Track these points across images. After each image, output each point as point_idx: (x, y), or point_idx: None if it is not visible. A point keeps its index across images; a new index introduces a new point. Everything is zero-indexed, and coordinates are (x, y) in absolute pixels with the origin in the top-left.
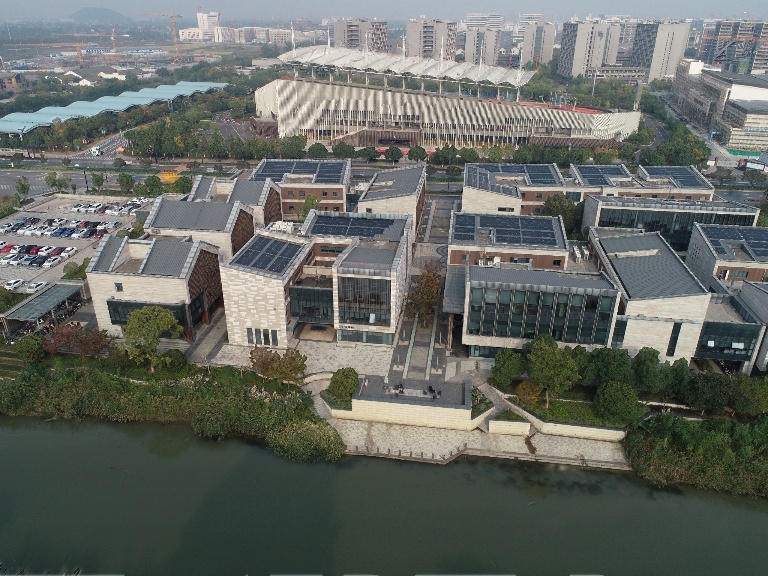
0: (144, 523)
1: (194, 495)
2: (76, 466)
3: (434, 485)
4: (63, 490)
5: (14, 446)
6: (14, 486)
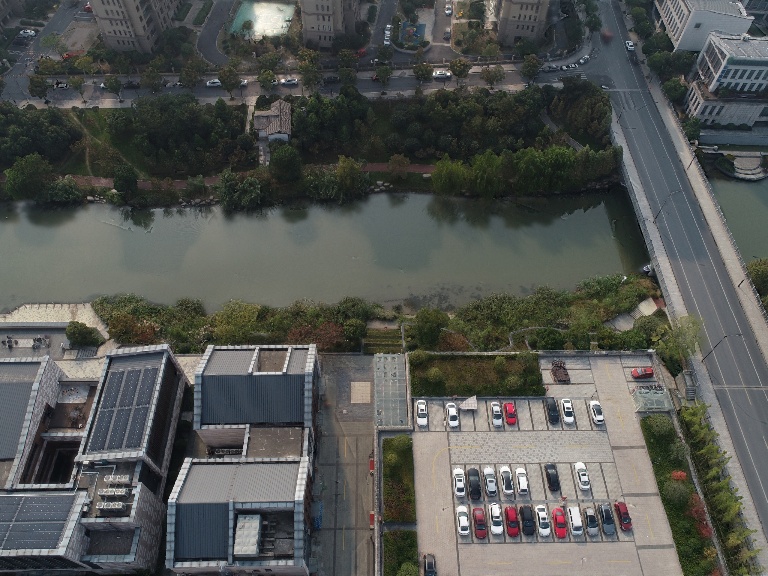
0: (212, 250)
1: (188, 264)
2: (268, 270)
3: (38, 289)
4: (264, 254)
5: (323, 284)
6: (297, 255)
